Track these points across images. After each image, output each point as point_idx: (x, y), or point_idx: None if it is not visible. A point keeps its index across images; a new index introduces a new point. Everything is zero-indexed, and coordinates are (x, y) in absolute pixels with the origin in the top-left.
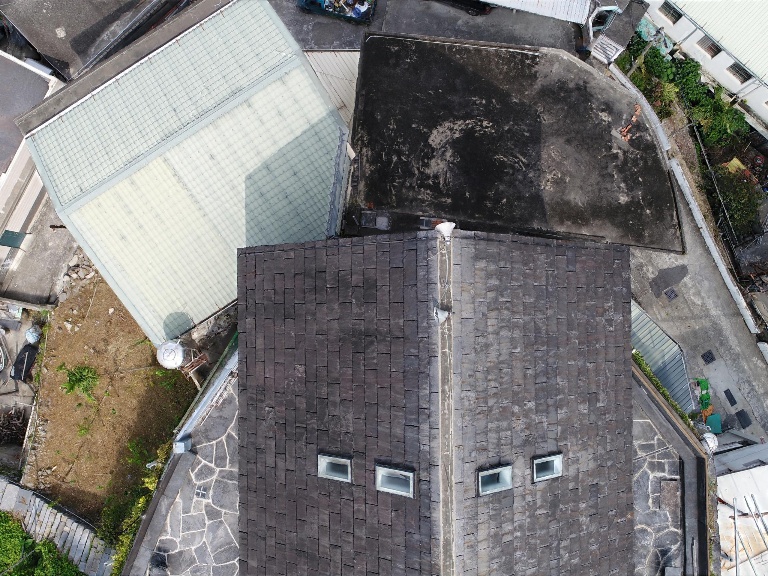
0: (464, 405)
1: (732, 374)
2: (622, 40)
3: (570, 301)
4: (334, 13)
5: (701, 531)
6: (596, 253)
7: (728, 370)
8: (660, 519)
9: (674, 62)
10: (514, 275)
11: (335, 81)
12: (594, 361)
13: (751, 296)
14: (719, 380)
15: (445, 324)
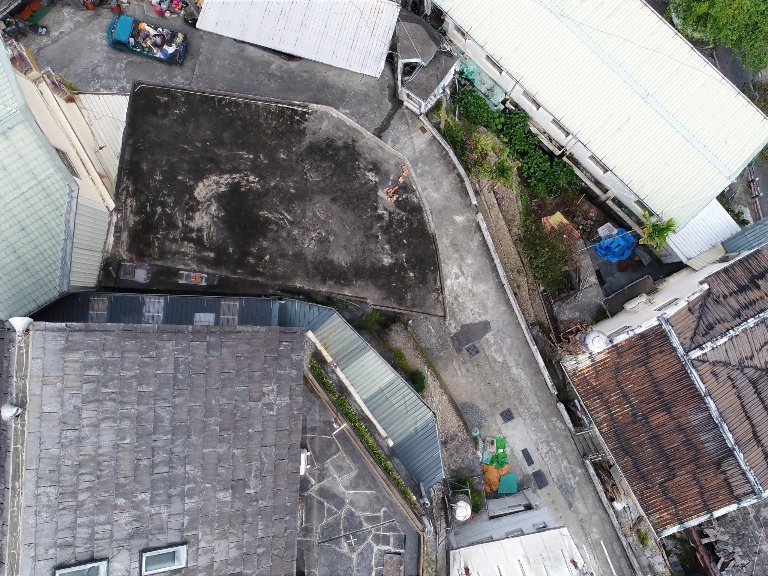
0: (41, 501)
1: (530, 433)
2: (424, 93)
3: (210, 387)
4: (143, 53)
5: None
6: (254, 336)
7: (527, 429)
8: None
9: (505, 112)
10: (126, 365)
11: (123, 125)
12: (244, 447)
13: (560, 354)
14: (517, 439)
15: (18, 419)
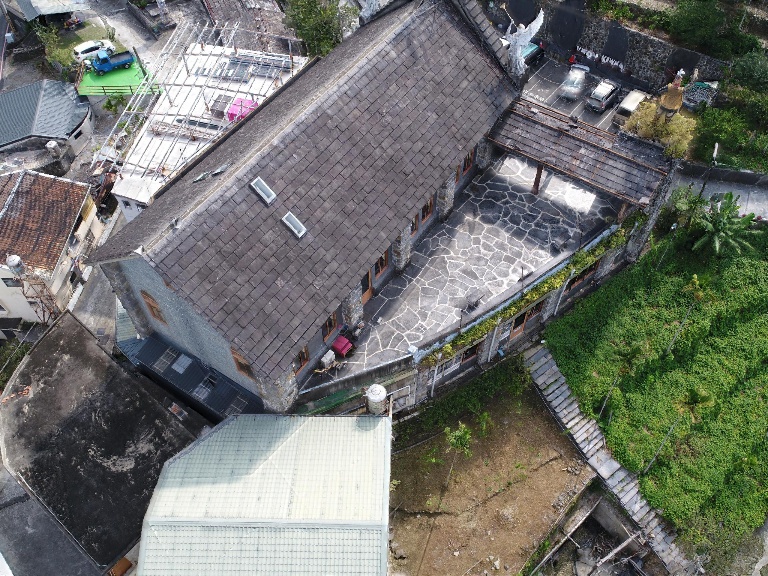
0: None
1: None
2: None
3: None
4: None
5: None
6: None
7: None
8: None
9: None
10: None
11: None
12: None
13: None
14: None
15: None
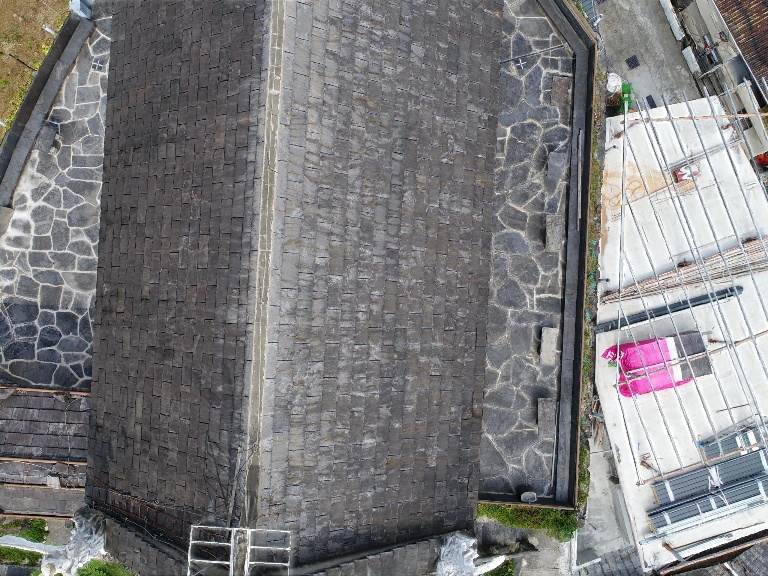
0: None
1: (655, 81)
2: None
3: None
4: None
5: (588, 120)
6: None
7: (651, 76)
8: (550, 114)
9: None
10: None
11: None
12: None
13: (682, 16)
14: (642, 86)
15: None
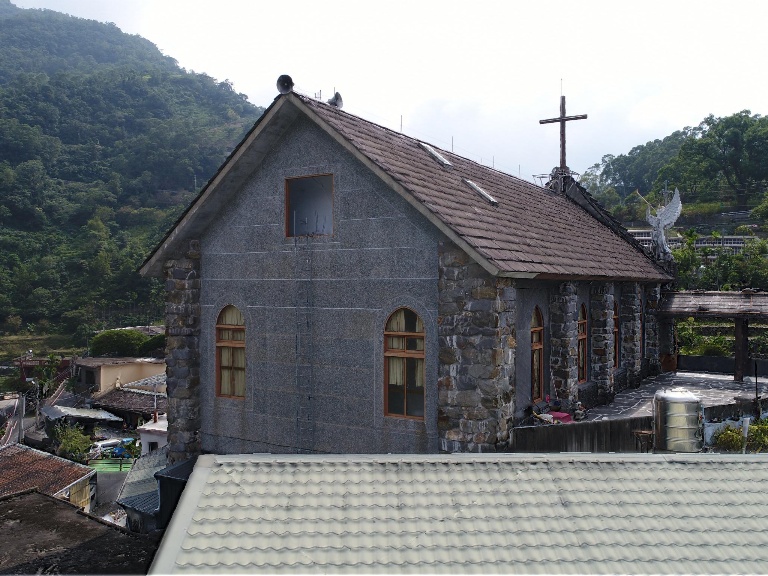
0: None
1: None
2: None
3: None
4: None
5: None
6: None
7: None
8: None
9: None
10: None
11: None
12: None
13: None
14: None
15: None
